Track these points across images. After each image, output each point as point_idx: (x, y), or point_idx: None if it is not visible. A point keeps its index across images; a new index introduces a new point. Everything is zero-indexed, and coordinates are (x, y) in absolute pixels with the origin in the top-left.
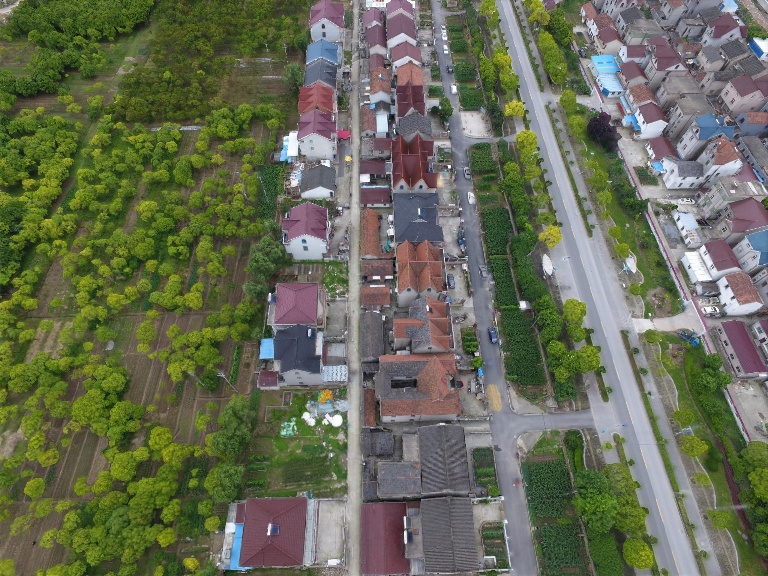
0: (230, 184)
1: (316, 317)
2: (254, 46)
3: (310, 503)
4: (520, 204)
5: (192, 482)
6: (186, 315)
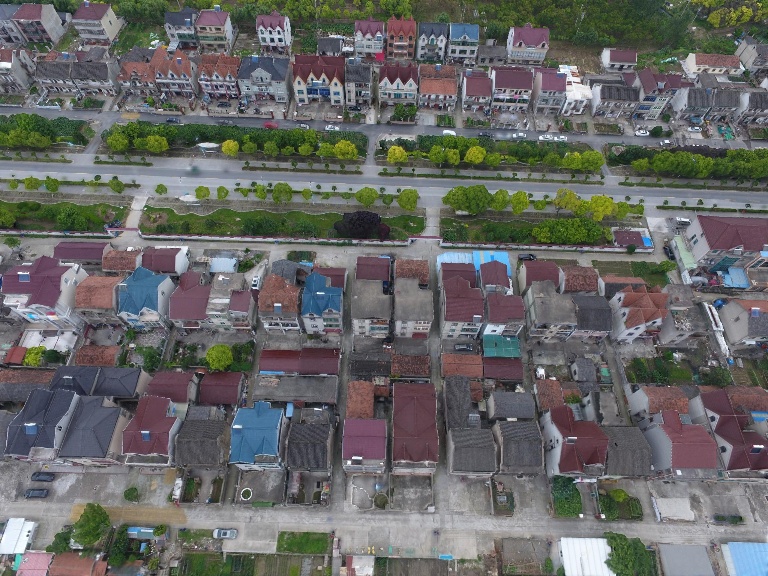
0: (340, 14)
1: (199, 25)
2: (490, 10)
3: (97, 22)
4: (269, 134)
5: (138, 3)
6: (241, 4)
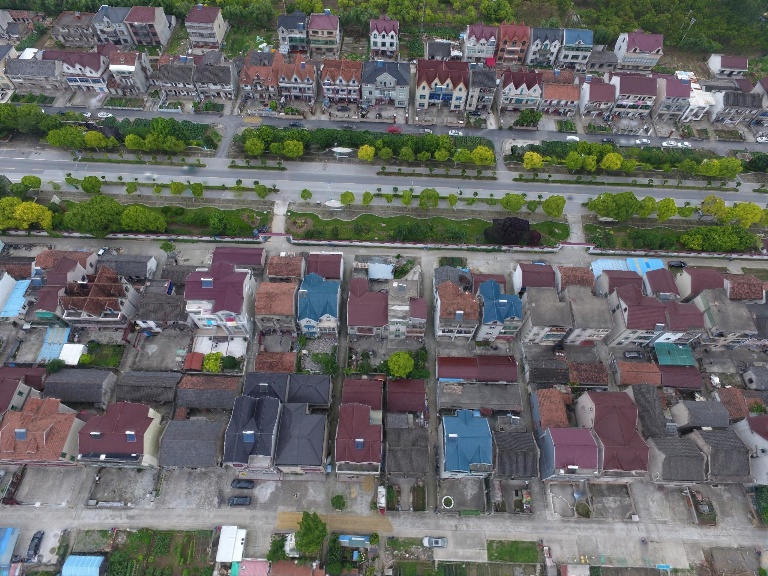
0: None
1: (312, 28)
2: (592, 15)
3: (210, 25)
4: (403, 139)
5: None
6: (339, 8)
